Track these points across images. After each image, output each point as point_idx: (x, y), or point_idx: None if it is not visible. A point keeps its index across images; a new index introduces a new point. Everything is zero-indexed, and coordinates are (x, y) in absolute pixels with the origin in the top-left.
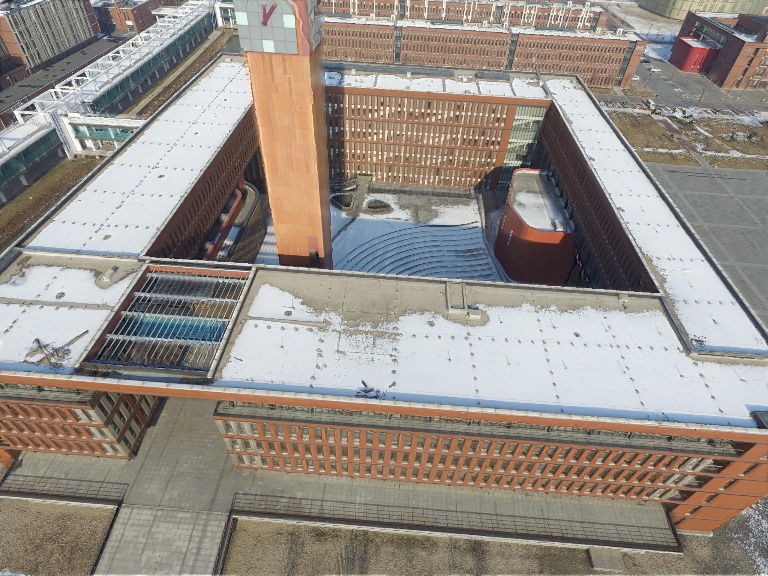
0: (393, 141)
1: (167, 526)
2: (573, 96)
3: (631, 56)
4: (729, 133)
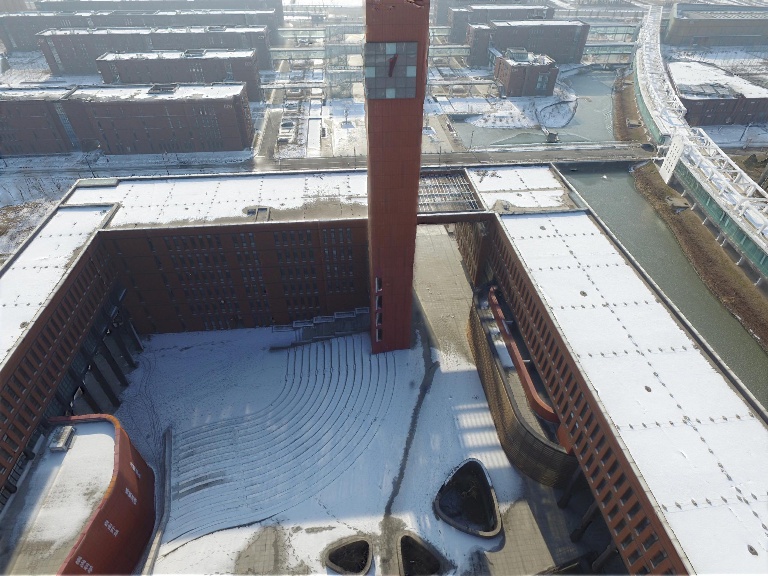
0: None
1: (421, 232)
2: None
3: None
4: None
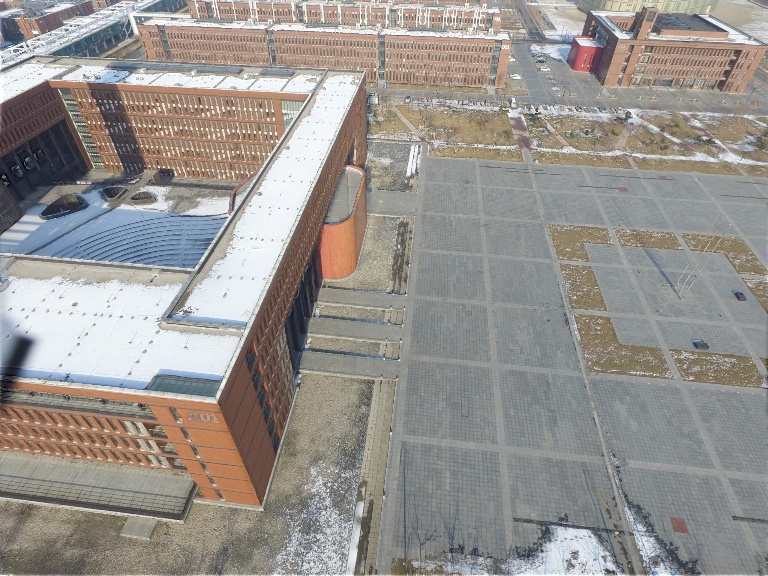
0: (179, 136)
1: None
2: (340, 91)
3: (499, 55)
4: (576, 130)
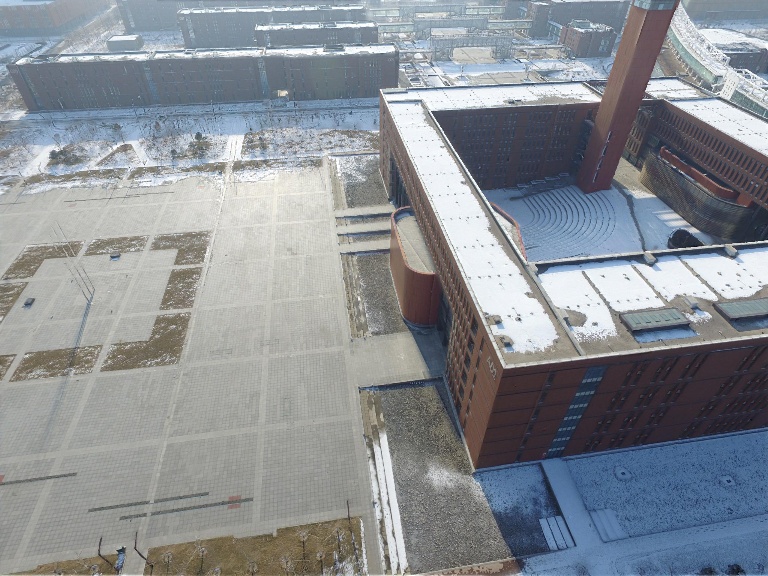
0: None
1: None
2: (498, 291)
3: None
4: None
